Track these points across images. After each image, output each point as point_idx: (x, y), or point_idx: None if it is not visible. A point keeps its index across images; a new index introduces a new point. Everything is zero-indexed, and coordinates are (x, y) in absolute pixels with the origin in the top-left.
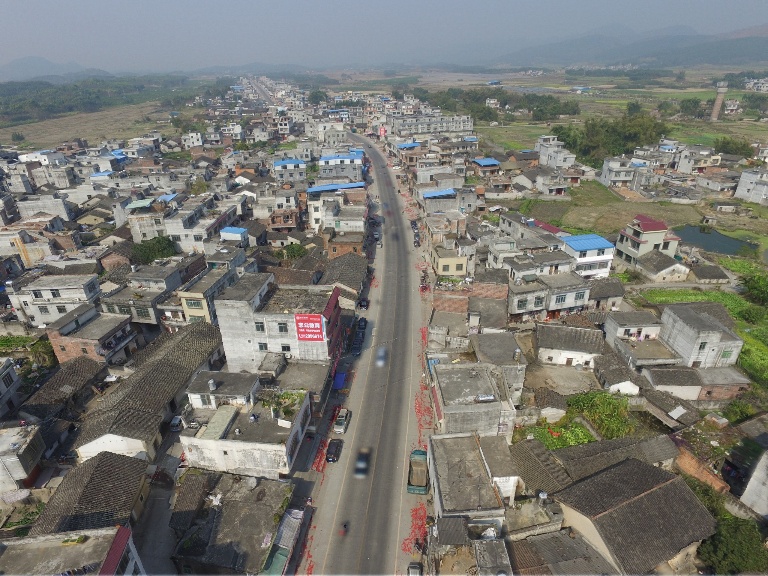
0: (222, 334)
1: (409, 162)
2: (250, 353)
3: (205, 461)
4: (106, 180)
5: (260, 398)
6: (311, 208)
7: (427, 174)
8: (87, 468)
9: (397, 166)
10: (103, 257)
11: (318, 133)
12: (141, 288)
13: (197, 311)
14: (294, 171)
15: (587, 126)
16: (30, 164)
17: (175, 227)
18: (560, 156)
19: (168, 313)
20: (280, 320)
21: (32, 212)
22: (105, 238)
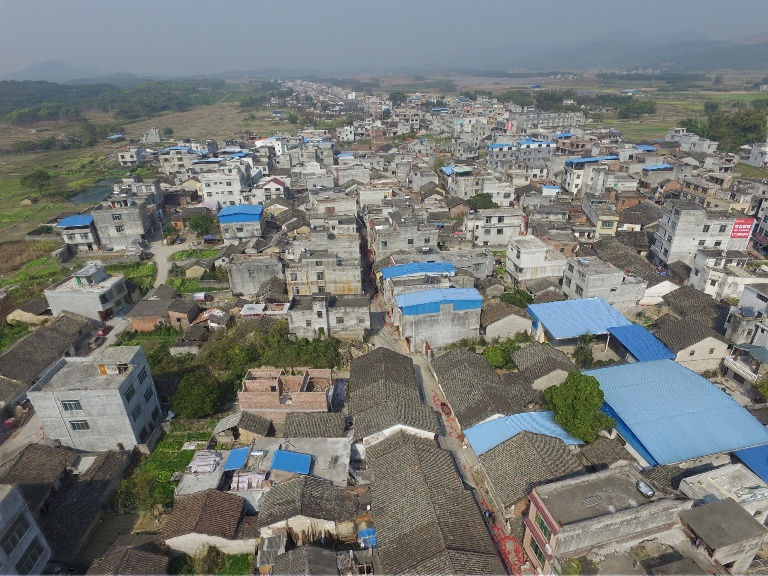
0: (676, 234)
1: (575, 148)
2: (690, 248)
3: (735, 294)
4: (351, 159)
5: (750, 262)
6: (575, 175)
7: (627, 154)
8: (685, 292)
9: (558, 152)
10: (453, 207)
11: (463, 126)
12: (543, 219)
13: (606, 230)
14: (507, 152)
15: (711, 120)
16: (270, 148)
17: (491, 187)
18: (706, 143)
19: (576, 234)
20: (723, 223)
21: (347, 179)
22: (430, 196)
